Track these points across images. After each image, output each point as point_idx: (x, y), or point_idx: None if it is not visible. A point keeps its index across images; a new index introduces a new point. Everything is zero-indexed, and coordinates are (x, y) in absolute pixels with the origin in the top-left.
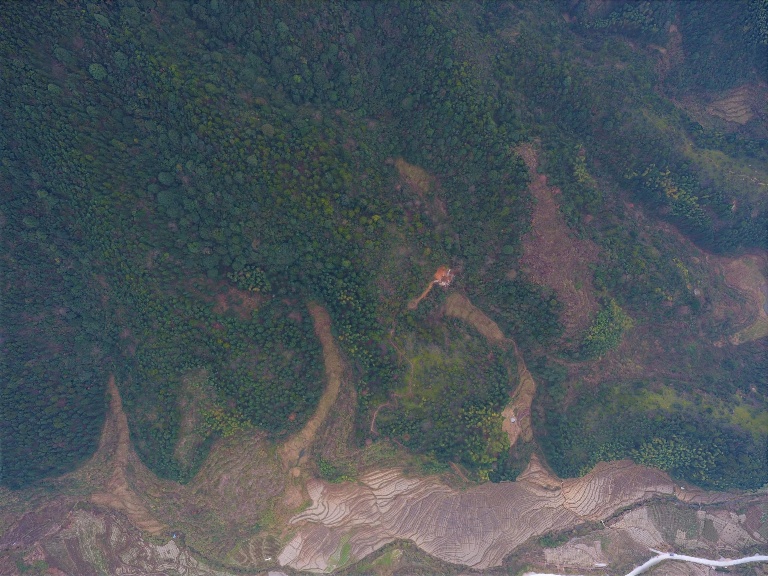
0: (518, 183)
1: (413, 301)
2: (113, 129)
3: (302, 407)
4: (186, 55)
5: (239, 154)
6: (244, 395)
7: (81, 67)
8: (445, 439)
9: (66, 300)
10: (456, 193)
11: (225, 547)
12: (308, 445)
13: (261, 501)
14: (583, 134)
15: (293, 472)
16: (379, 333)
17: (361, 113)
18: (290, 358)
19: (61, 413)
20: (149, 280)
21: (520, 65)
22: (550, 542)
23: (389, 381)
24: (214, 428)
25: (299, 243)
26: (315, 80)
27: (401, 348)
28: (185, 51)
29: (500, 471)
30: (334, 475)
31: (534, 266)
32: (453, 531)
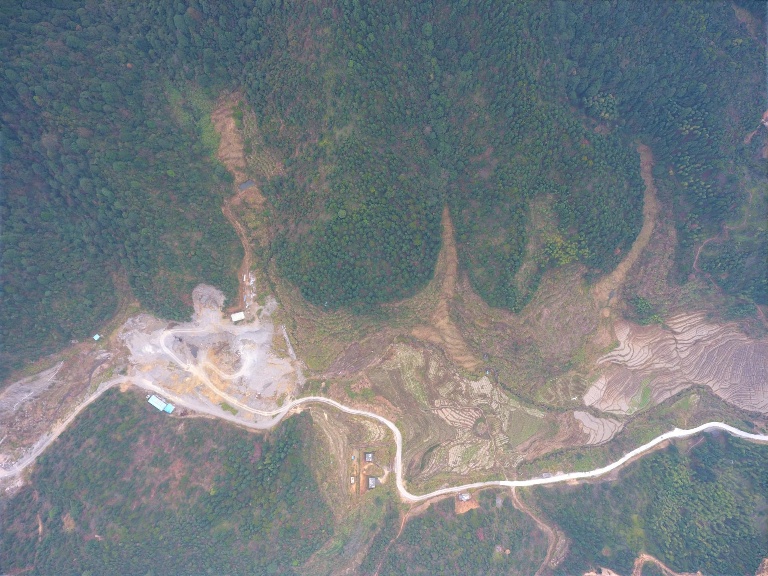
0: None
1: (747, 135)
2: None
3: (623, 244)
4: None
5: None
6: (591, 219)
7: None
8: None
9: (433, 118)
10: None
11: (536, 384)
12: (618, 286)
13: (575, 338)
14: None
15: (603, 312)
16: (724, 161)
17: None
18: (626, 189)
19: (418, 232)
20: (539, 88)
21: None
22: None
23: (726, 211)
24: (553, 255)
25: (665, 64)
26: None
27: (742, 177)
28: None
29: None
30: (646, 315)
31: None
32: (748, 378)
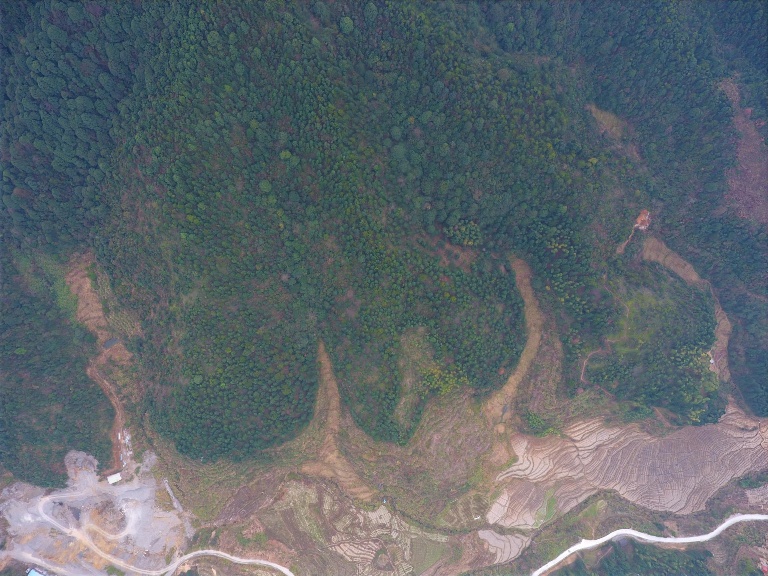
0: (720, 119)
1: (620, 245)
2: (356, 84)
3: (508, 362)
4: (424, 5)
5: (481, 100)
6: (465, 350)
7: (332, 21)
8: (658, 382)
9: (289, 266)
10: (651, 136)
11: (435, 508)
12: (510, 401)
13: (470, 459)
14: (764, 70)
15: (498, 429)
16: (595, 278)
17: (560, 61)
18: (501, 311)
19: (287, 380)
20: (386, 236)
21: (713, 2)
22: (752, 482)
23: (604, 326)
24: (432, 386)
25: (520, 191)
26: (527, 27)
27: (616, 292)
28: (423, 1)
29: (708, 412)
30: (540, 428)
31: (741, 201)
32: (655, 478)
